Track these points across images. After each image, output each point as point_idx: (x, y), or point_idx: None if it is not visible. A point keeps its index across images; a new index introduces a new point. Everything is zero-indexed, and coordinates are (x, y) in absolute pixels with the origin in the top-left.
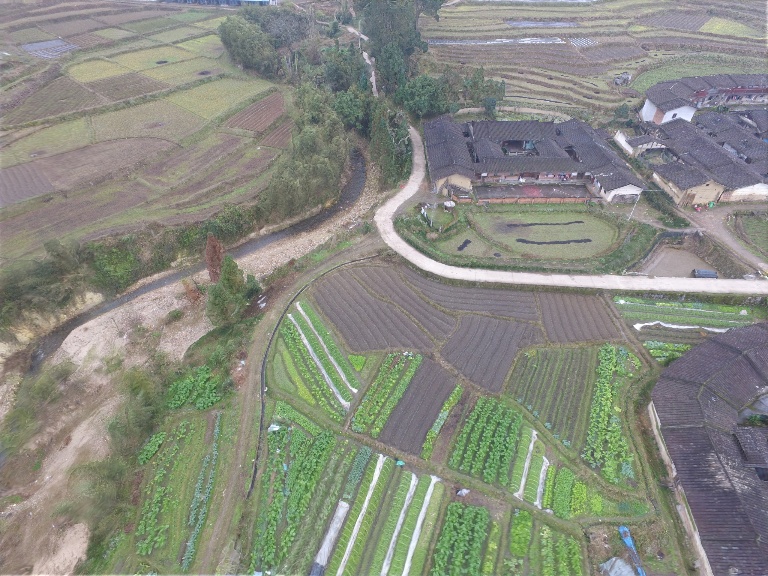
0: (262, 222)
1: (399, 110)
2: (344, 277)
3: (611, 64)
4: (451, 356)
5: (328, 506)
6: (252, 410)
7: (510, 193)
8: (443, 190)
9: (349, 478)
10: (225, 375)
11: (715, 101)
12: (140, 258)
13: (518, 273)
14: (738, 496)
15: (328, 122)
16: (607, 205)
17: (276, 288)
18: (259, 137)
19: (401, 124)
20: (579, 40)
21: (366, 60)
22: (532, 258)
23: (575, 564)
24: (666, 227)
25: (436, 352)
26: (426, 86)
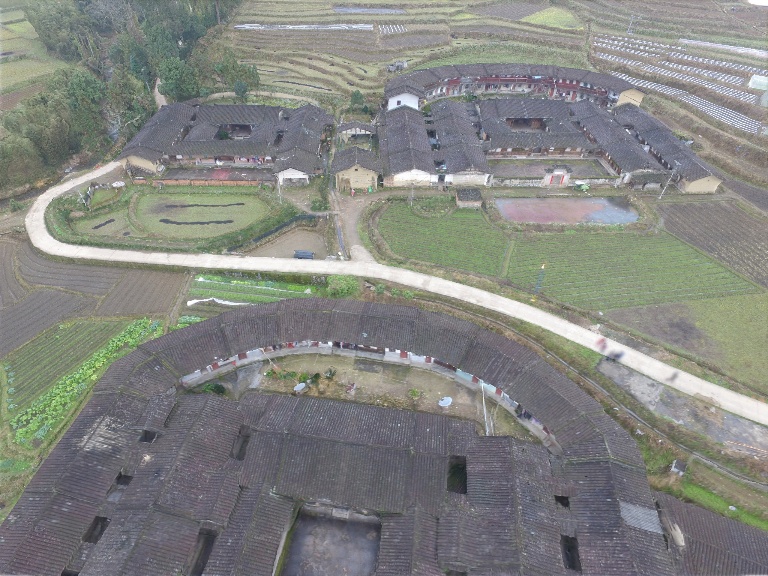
0: None
1: None
2: None
3: (404, 51)
4: None
5: None
6: None
7: (197, 175)
8: (127, 171)
9: None
10: None
11: (471, 90)
12: None
13: (121, 251)
14: (78, 453)
15: (50, 103)
16: None
17: None
18: None
19: (134, 106)
20: (391, 27)
21: (180, 43)
22: None
23: None
24: (310, 210)
25: None
26: (173, 69)
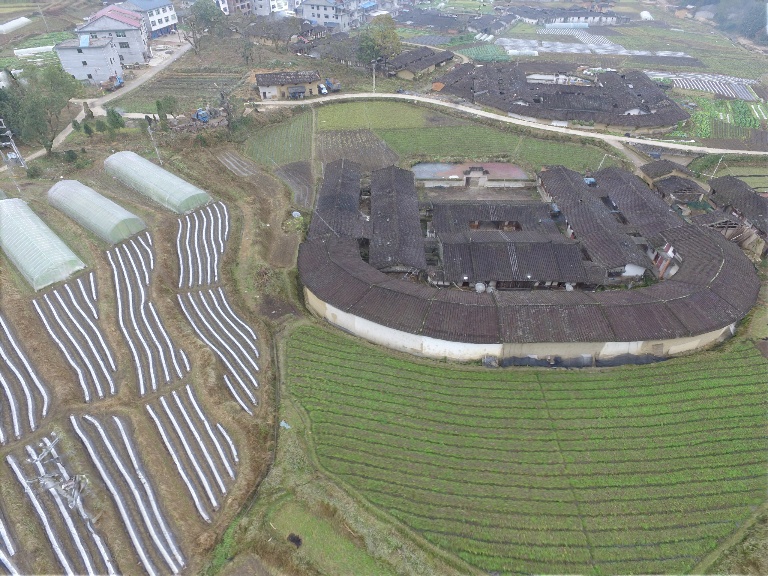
0: None
1: None
2: None
3: None
4: None
5: None
6: None
7: None
8: None
9: None
10: None
11: None
12: None
13: None
14: None
15: None
16: None
17: None
18: None
19: None
20: None
21: None
22: None
23: None
24: None
25: None
26: None
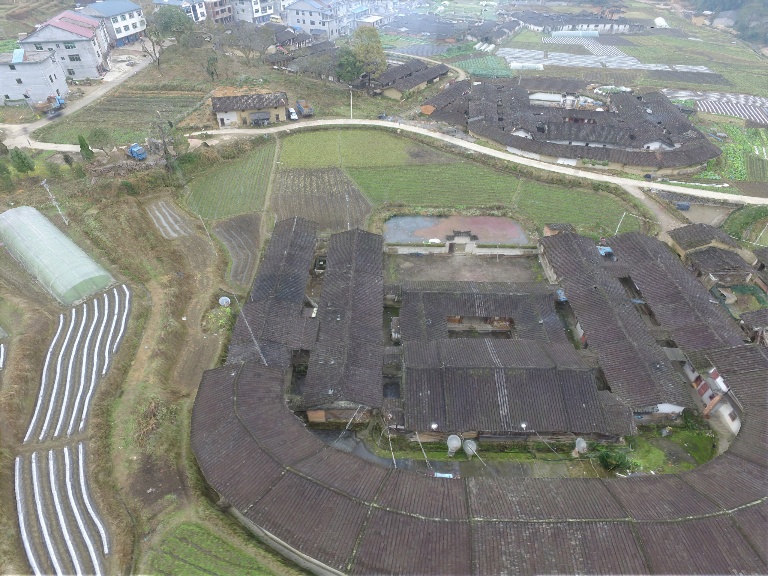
0: None
1: None
2: None
3: None
4: None
5: None
6: None
7: None
8: None
9: None
10: None
11: None
12: None
13: None
14: (691, 129)
15: None
16: None
17: None
18: None
19: None
20: None
21: None
22: None
23: None
24: None
25: None
26: None
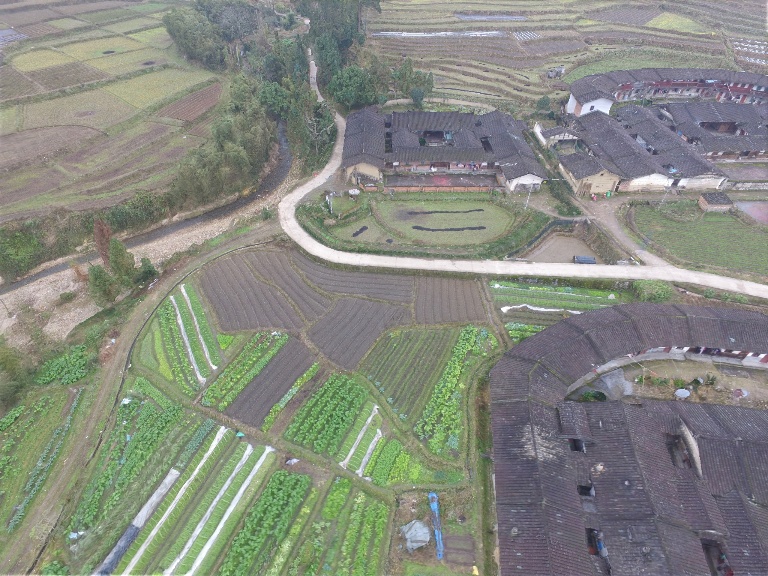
0: (176, 209)
1: (325, 100)
2: (235, 261)
3: (549, 57)
4: (316, 336)
5: (158, 473)
6: (111, 385)
7: (419, 182)
8: (352, 178)
9: (186, 448)
10: (97, 353)
11: (641, 94)
12: (44, 242)
13: (402, 258)
14: (537, 464)
15: (249, 111)
16: (510, 194)
17: (169, 271)
18: (187, 126)
19: (324, 114)
20: (524, 34)
21: None
22: (420, 244)
23: (378, 527)
24: (560, 215)
25: (303, 332)
26: (353, 77)
